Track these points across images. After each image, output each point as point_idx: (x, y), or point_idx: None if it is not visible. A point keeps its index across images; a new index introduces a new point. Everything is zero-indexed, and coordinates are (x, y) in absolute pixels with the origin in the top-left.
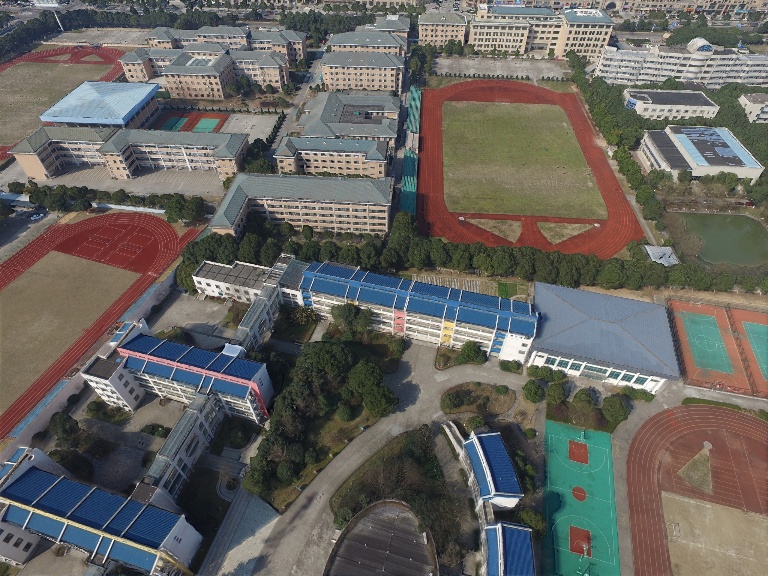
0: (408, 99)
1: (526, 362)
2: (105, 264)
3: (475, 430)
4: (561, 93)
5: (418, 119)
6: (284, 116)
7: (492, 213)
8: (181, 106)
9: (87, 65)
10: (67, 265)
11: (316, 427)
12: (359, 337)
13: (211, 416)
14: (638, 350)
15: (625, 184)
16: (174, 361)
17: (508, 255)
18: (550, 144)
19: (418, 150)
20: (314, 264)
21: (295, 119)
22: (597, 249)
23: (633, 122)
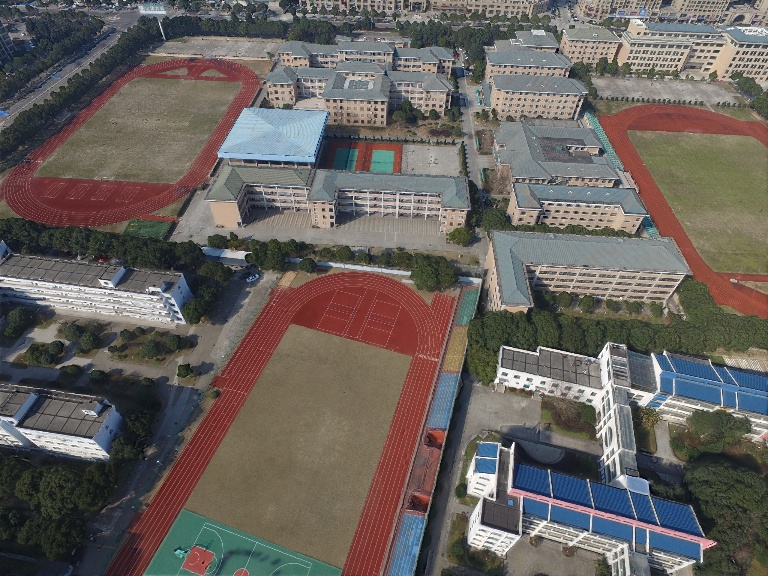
0: None
1: None
2: (363, 343)
3: None
4: (746, 122)
5: (614, 153)
6: (464, 148)
7: (763, 274)
8: (342, 134)
9: (212, 82)
10: (319, 344)
11: None
12: (728, 449)
13: None
14: None
15: None
16: (592, 508)
17: None
18: None
19: None
20: (658, 358)
21: (477, 152)
22: None
23: None
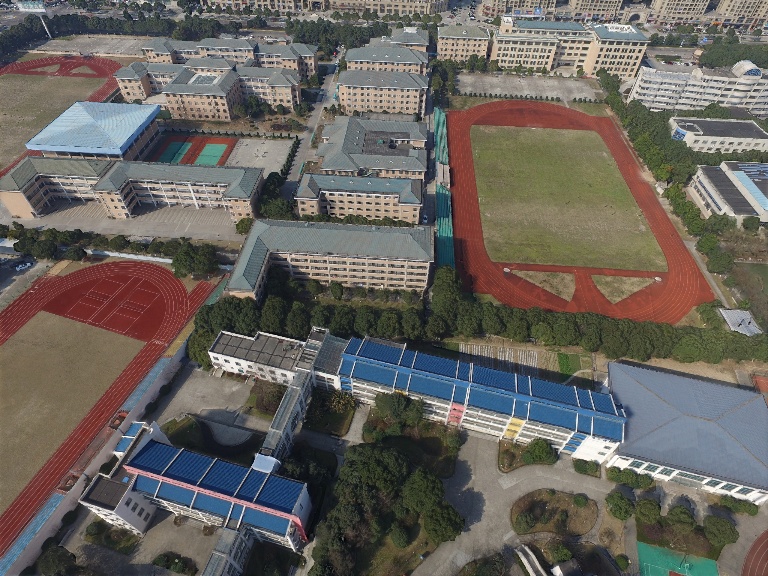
0: (432, 122)
1: (604, 462)
2: (103, 329)
3: (561, 566)
4: (596, 117)
5: (446, 147)
6: (298, 142)
7: (540, 263)
8: (183, 128)
9: (78, 78)
10: (59, 330)
11: (366, 556)
12: (408, 431)
13: (240, 548)
14: (744, 458)
15: (681, 228)
16: (195, 484)
17: (573, 325)
18: (592, 178)
19: (449, 184)
20: (353, 341)
21: (310, 145)
22: (663, 310)
23: (685, 156)
